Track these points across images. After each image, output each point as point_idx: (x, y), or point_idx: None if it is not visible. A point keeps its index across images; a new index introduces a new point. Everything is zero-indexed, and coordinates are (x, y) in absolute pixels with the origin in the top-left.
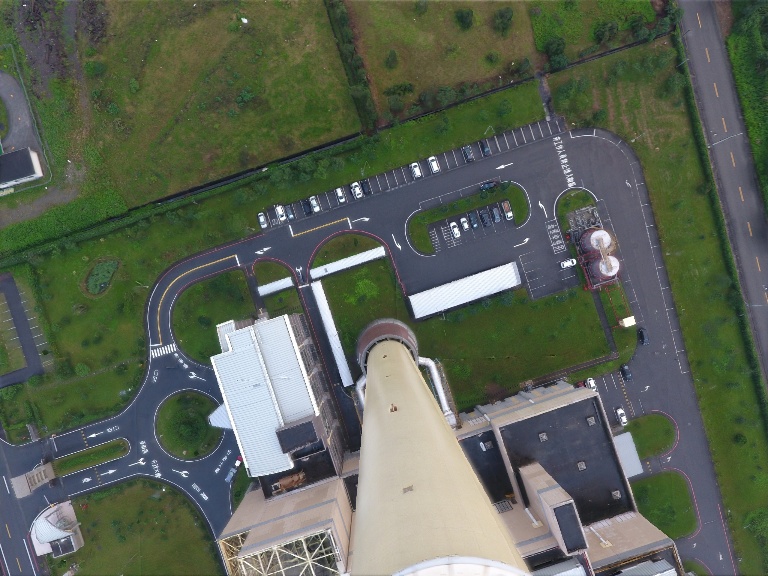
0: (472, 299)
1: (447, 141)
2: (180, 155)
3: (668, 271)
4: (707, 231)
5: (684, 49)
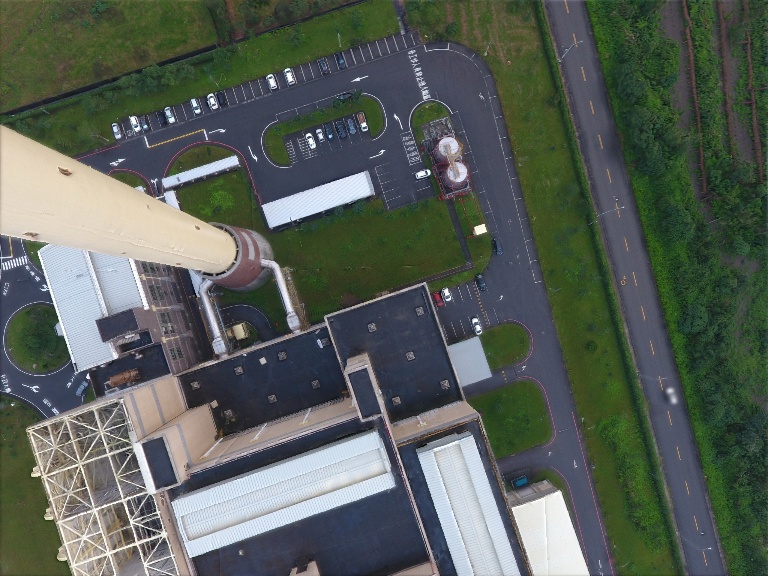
0: (326, 208)
1: (303, 53)
2: (33, 65)
3: (520, 182)
4: (558, 143)
5: None
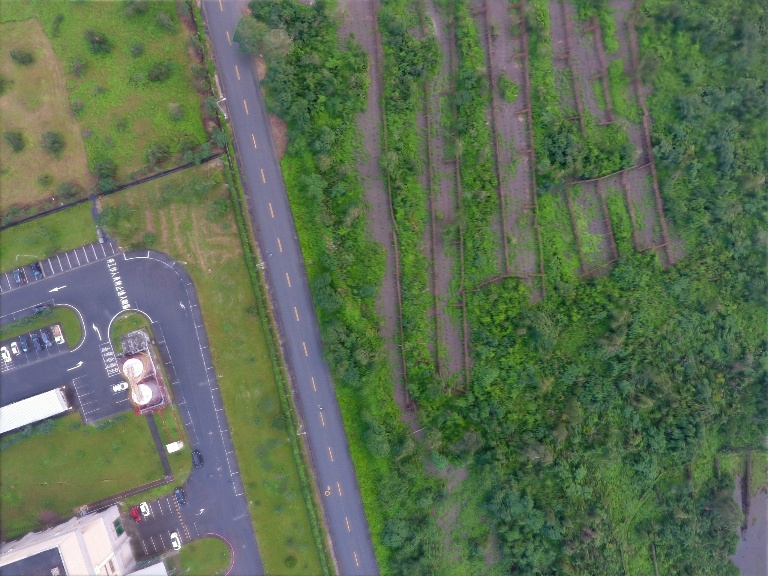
0: (17, 426)
1: None
2: None
3: (220, 393)
4: (260, 352)
5: (238, 170)
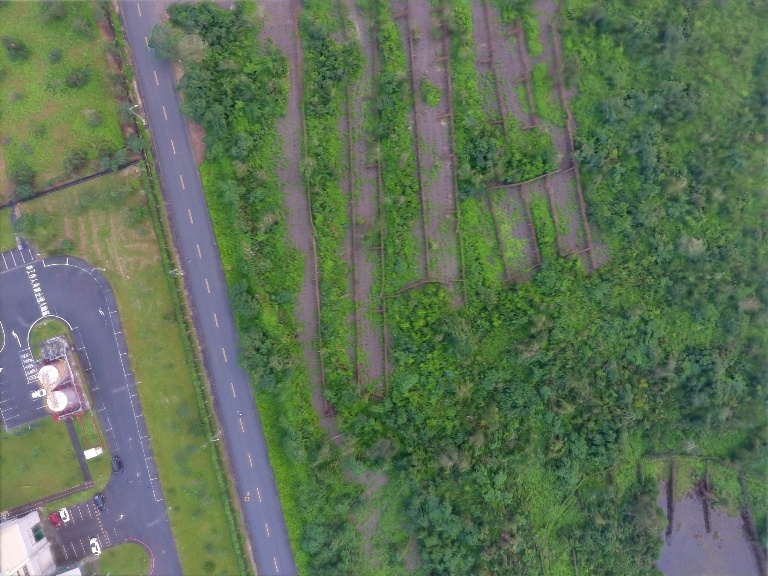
0: None
1: None
2: None
3: (139, 400)
4: (178, 359)
5: (157, 176)
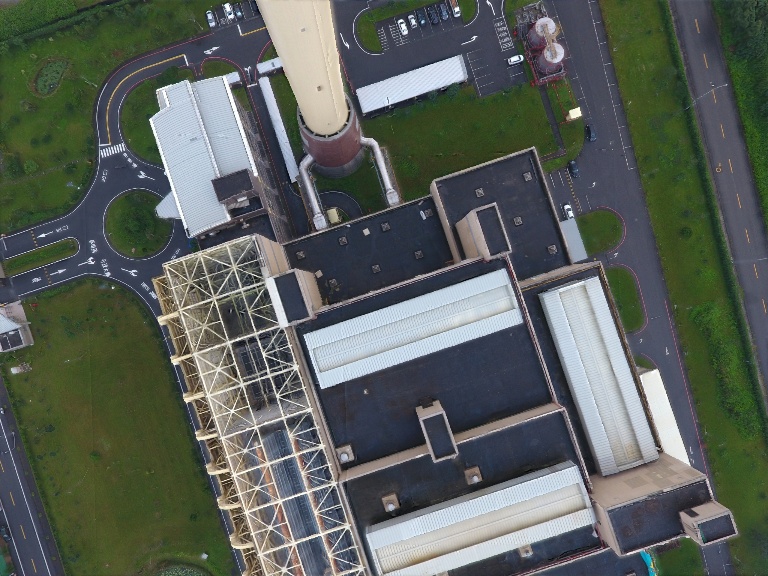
0: (419, 93)
1: None
2: None
3: (615, 66)
4: (654, 27)
5: None
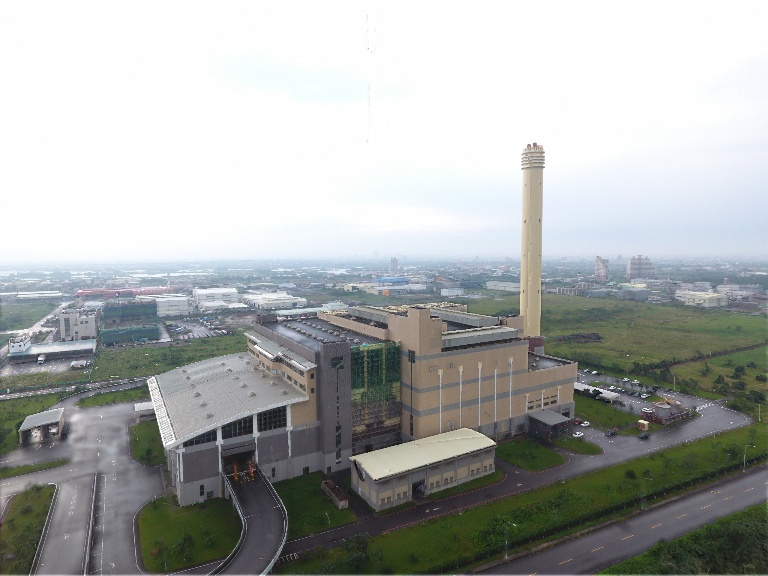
0: None
1: None
2: None
3: None
4: None
5: None
